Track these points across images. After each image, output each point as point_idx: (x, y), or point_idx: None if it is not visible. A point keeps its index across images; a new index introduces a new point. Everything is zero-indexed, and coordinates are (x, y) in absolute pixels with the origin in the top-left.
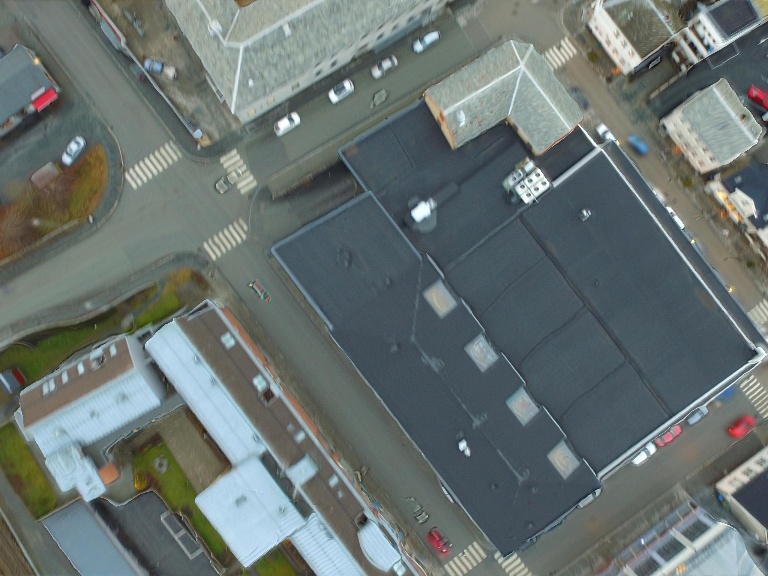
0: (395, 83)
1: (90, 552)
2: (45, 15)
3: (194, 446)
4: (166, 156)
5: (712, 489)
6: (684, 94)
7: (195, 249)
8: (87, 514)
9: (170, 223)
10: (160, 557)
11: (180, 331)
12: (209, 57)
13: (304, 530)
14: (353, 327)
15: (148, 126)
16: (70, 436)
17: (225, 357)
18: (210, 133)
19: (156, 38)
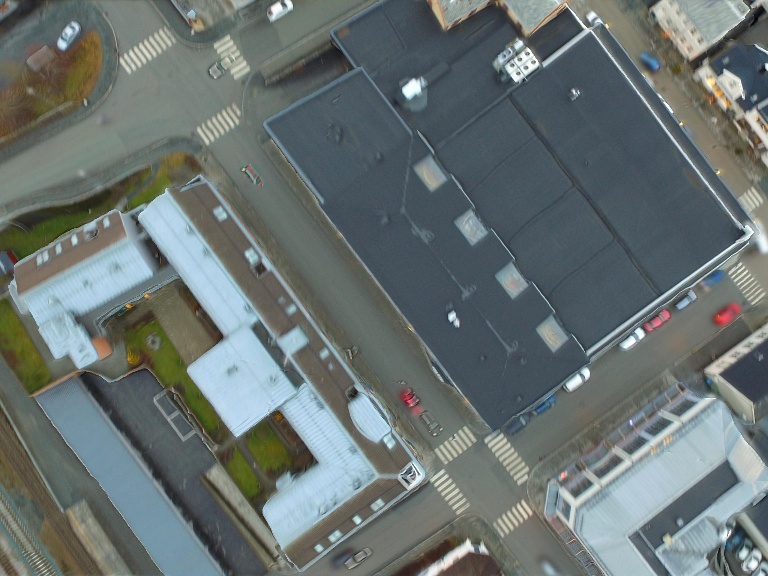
0: None
1: (83, 429)
2: None
3: (187, 324)
4: (160, 42)
5: (700, 374)
6: None
7: (189, 134)
8: (80, 392)
9: (164, 107)
10: (153, 439)
11: (173, 200)
12: None
13: (295, 400)
14: (344, 201)
15: (142, 12)
16: (63, 306)
17: (217, 229)
18: (204, 19)
19: None
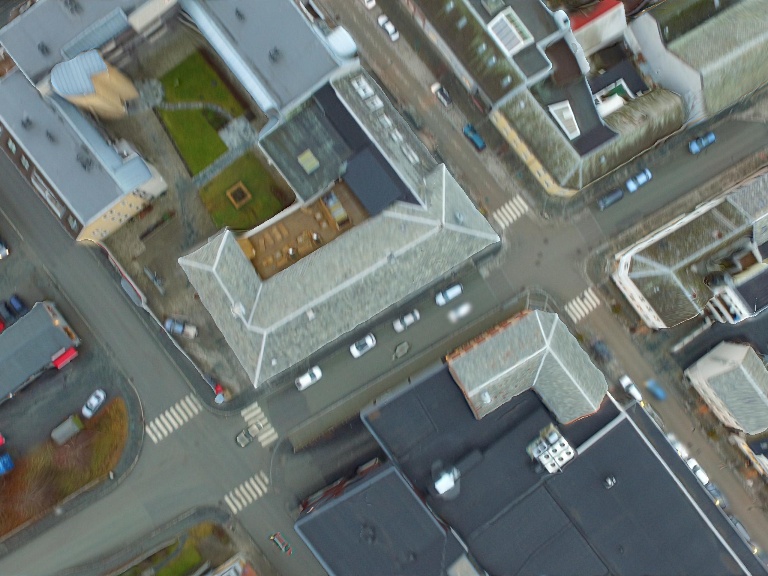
0: (417, 335)
1: None
2: (64, 264)
3: None
4: (187, 409)
5: None
6: (708, 345)
7: (216, 502)
8: None
9: (191, 477)
10: None
11: None
12: (232, 335)
13: None
14: None
15: (168, 378)
16: None
17: None
18: (231, 387)
19: (177, 295)
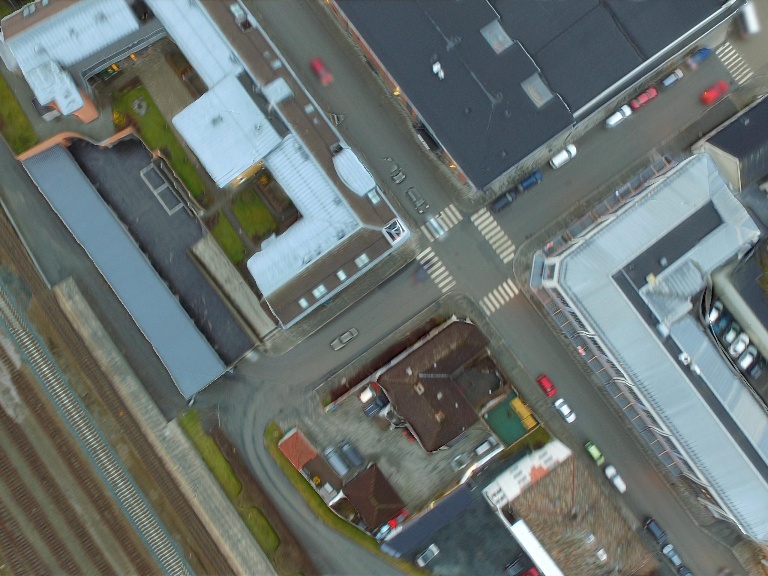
0: None
1: (70, 195)
2: None
3: (173, 90)
4: None
5: (687, 152)
6: None
7: None
8: (67, 159)
9: None
10: (139, 213)
11: None
12: None
13: (279, 152)
14: None
15: None
16: (50, 55)
17: None
18: None
19: None
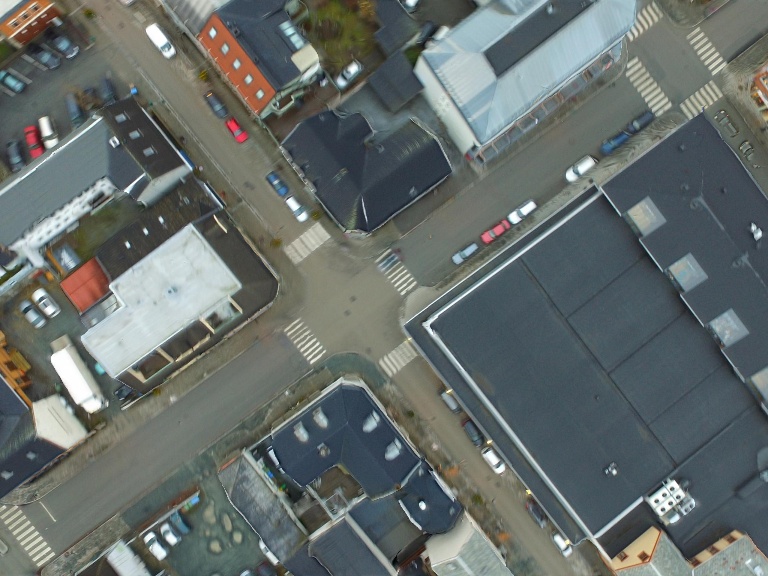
0: None
1: None
2: None
3: None
4: None
5: (450, 173)
6: None
7: None
8: None
9: None
10: None
11: None
12: None
13: None
14: None
15: None
16: None
17: None
18: None
19: None
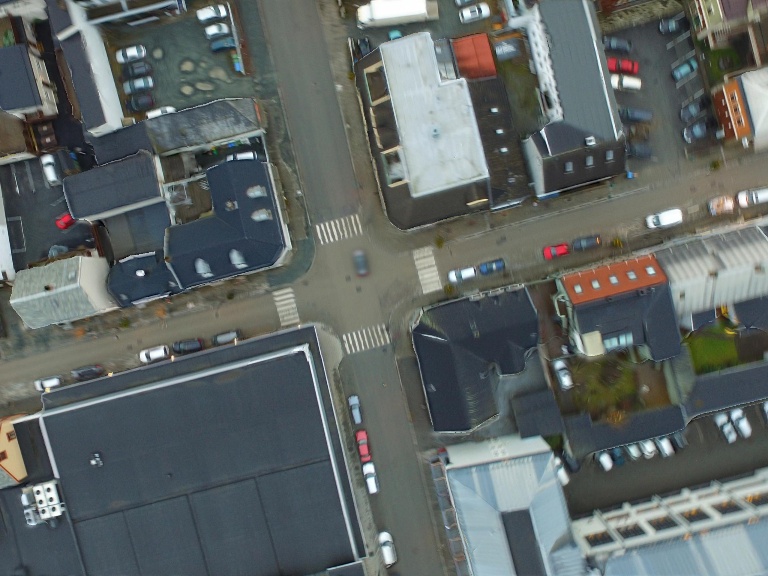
0: None
1: None
2: None
3: None
4: None
5: None
6: None
7: None
8: None
9: None
10: None
11: None
12: None
13: None
14: None
15: None
16: None
17: None
18: None
19: None
